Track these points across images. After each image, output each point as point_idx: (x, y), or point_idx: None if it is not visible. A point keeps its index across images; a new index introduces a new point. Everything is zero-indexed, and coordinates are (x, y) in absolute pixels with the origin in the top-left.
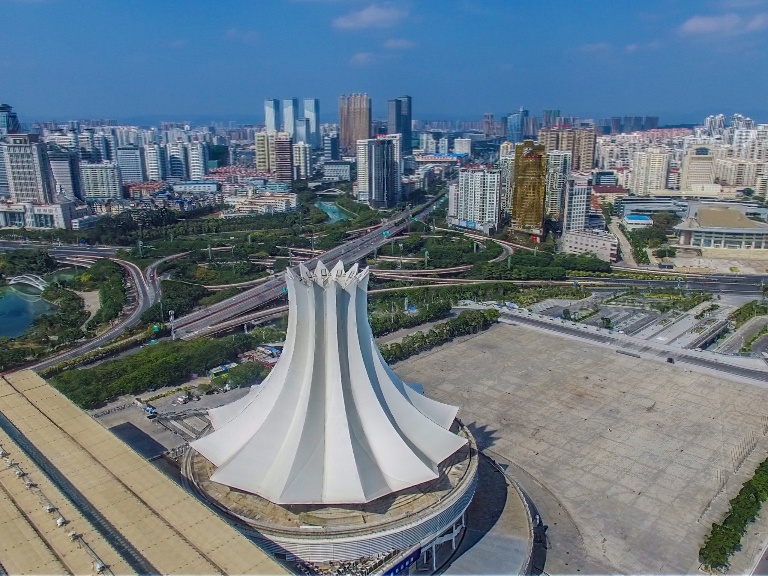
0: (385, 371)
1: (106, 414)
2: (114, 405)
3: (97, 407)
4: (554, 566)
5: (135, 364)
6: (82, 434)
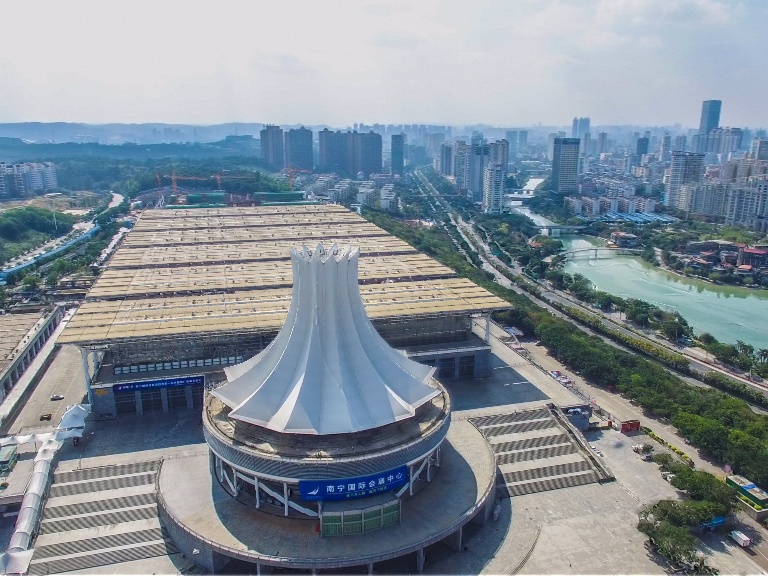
0: (290, 340)
1: (574, 392)
2: (650, 421)
3: (648, 414)
4: (164, 565)
5: (762, 432)
6: (386, 312)
